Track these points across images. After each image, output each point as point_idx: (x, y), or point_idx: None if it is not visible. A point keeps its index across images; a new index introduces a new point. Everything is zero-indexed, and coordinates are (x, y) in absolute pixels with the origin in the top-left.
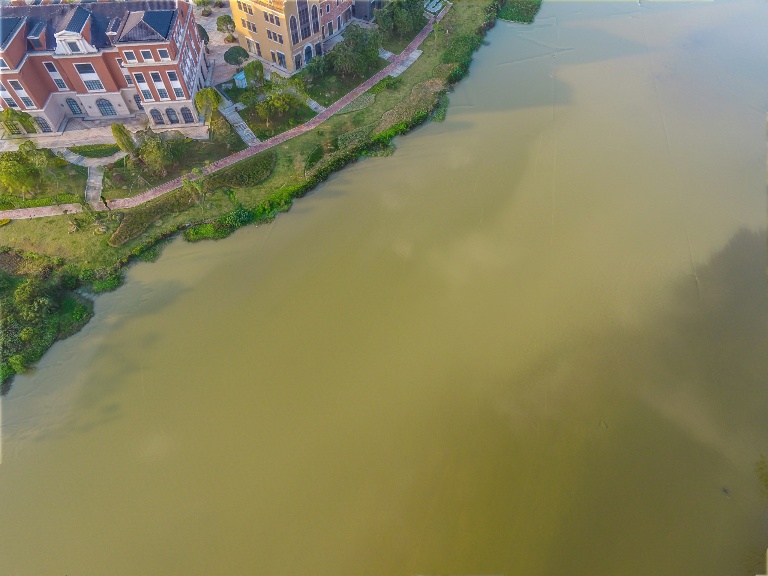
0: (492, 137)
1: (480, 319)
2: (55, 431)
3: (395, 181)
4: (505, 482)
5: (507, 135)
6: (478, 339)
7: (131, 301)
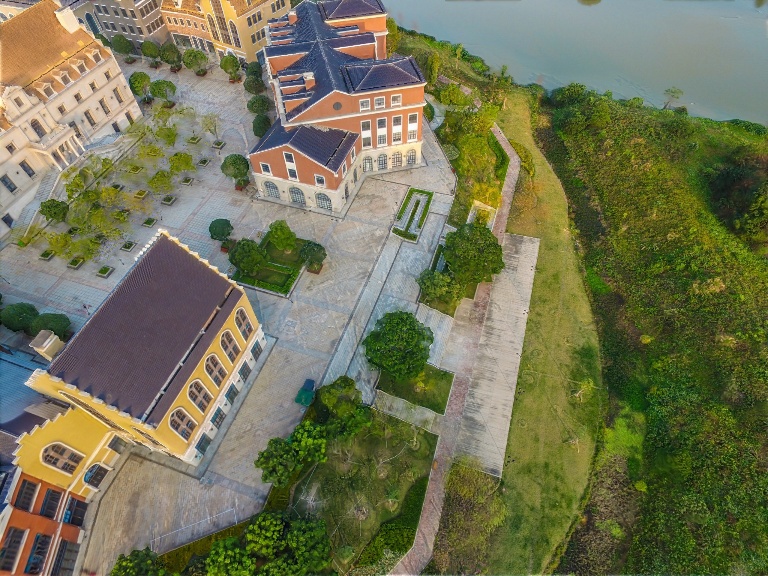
0: None
1: None
2: (629, 78)
3: (408, 12)
4: None
5: None
6: None
7: (544, 77)
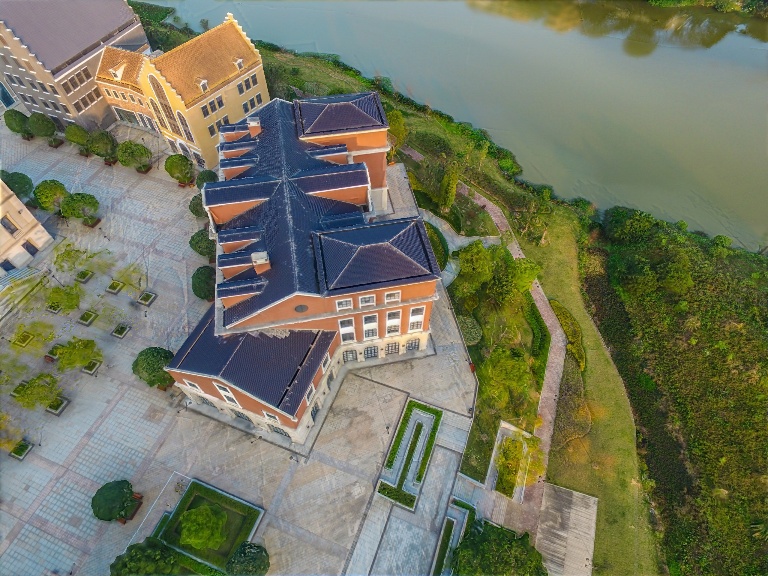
0: (359, 35)
1: (536, 46)
2: (706, 196)
3: (421, 76)
4: (624, 44)
5: (356, 30)
6: (550, 47)
7: (594, 189)
